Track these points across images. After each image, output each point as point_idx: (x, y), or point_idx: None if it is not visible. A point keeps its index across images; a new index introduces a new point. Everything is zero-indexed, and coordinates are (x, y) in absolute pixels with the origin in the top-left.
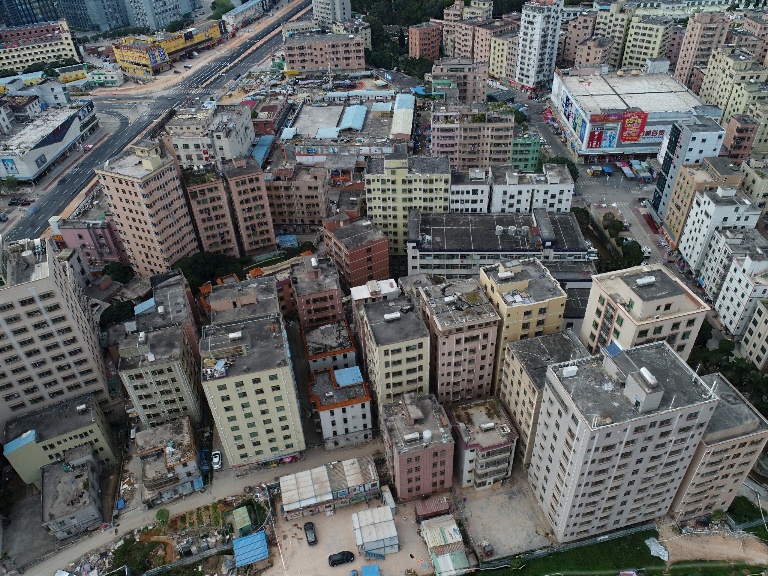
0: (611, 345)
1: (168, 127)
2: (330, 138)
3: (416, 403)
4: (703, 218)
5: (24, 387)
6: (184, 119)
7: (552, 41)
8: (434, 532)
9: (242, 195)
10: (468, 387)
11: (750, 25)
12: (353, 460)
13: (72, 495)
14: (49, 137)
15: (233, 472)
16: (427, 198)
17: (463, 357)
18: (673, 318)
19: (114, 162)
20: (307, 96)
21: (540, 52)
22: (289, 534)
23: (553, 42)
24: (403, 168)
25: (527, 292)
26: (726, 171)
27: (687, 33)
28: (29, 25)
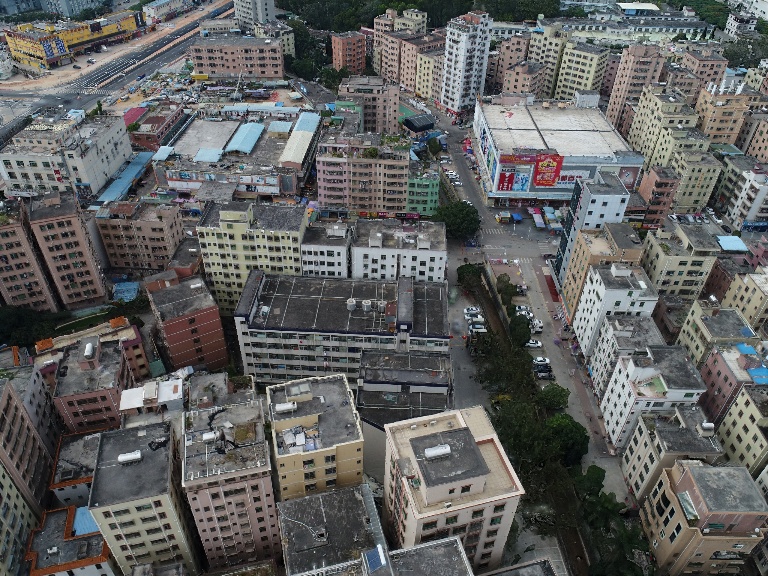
0: (373, 552)
1: (15, 139)
2: (209, 162)
3: None
4: (594, 299)
5: None
6: (37, 131)
7: (480, 63)
8: None
9: (51, 241)
10: (246, 540)
11: (689, 60)
12: None
13: None
14: None
15: None
16: (274, 257)
17: (228, 511)
18: (470, 507)
19: None
20: (201, 108)
21: (465, 74)
22: None
23: (481, 64)
24: (242, 221)
25: (316, 429)
26: (625, 243)
27: (621, 65)
28: None
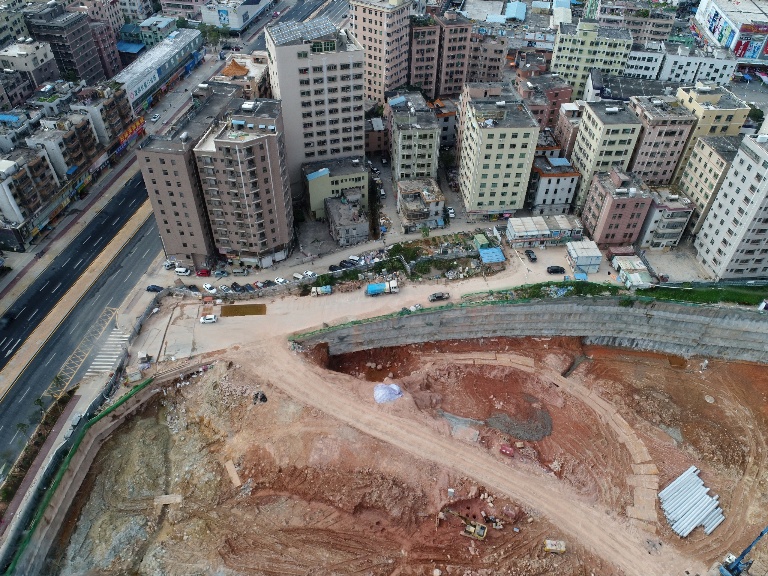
0: None
1: None
2: (499, 23)
3: (623, 172)
4: None
5: (319, 139)
6: None
7: None
8: (625, 262)
9: (451, 42)
10: (652, 179)
11: None
12: (563, 215)
13: (352, 216)
14: None
15: (464, 220)
16: (607, 61)
17: (658, 149)
18: None
19: None
20: None
21: None
22: (514, 255)
23: None
24: (594, 31)
25: (718, 105)
26: None
27: None
28: None
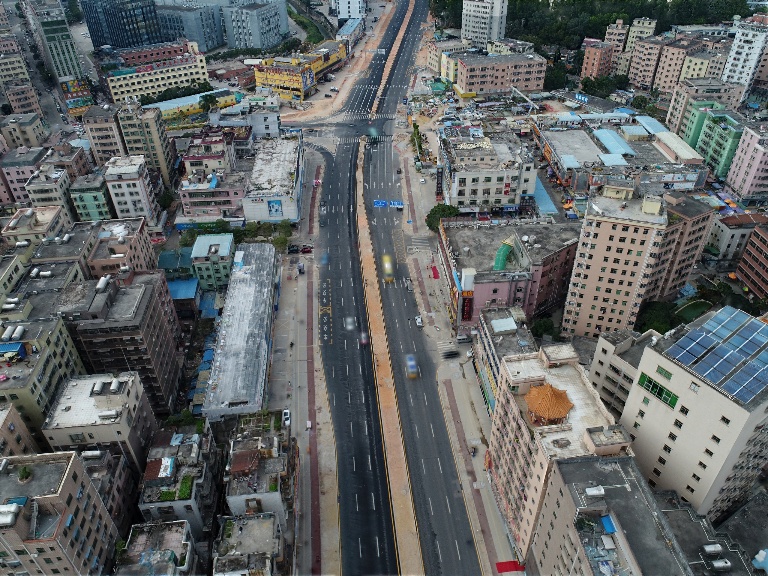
0: None
1: (460, 159)
2: (622, 165)
3: None
4: None
5: None
6: (469, 149)
7: None
8: None
9: (690, 236)
10: None
11: None
12: None
13: None
14: (296, 173)
15: None
16: None
17: None
18: None
19: (591, 205)
20: (540, 120)
21: (753, 71)
22: None
23: None
24: None
25: None
26: None
27: None
28: (146, 46)
